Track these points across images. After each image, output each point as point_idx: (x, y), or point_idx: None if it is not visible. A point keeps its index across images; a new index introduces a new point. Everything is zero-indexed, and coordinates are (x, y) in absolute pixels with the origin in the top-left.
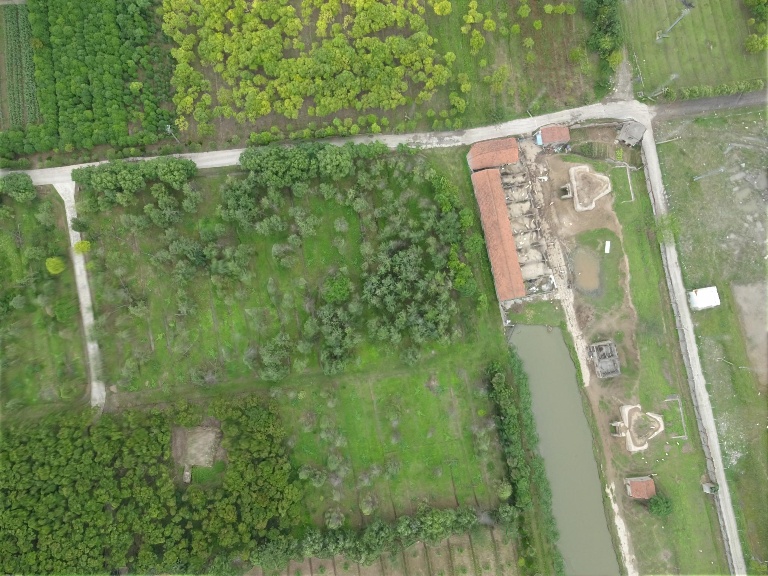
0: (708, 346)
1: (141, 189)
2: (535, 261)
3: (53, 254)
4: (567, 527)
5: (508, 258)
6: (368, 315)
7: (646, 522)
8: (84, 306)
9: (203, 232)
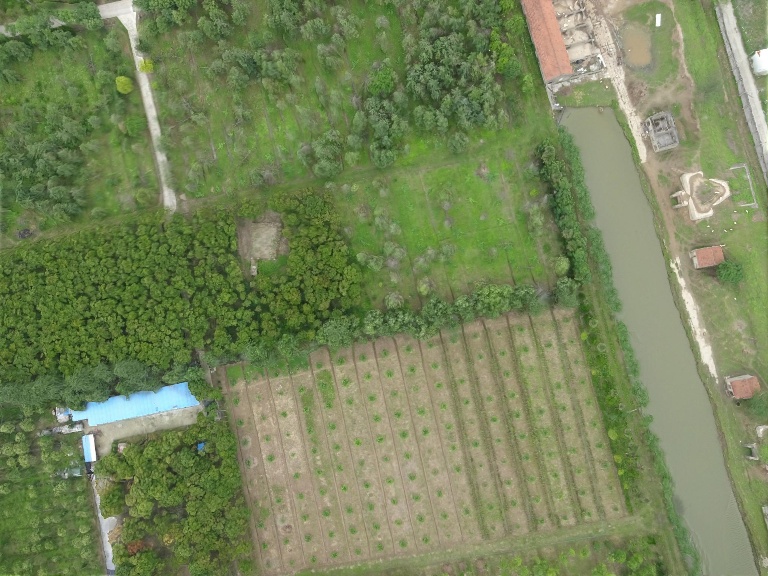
0: None
1: (193, 5)
2: (581, 41)
3: (121, 76)
4: (630, 300)
5: (552, 35)
6: (414, 107)
7: (716, 293)
8: (152, 124)
9: (252, 41)
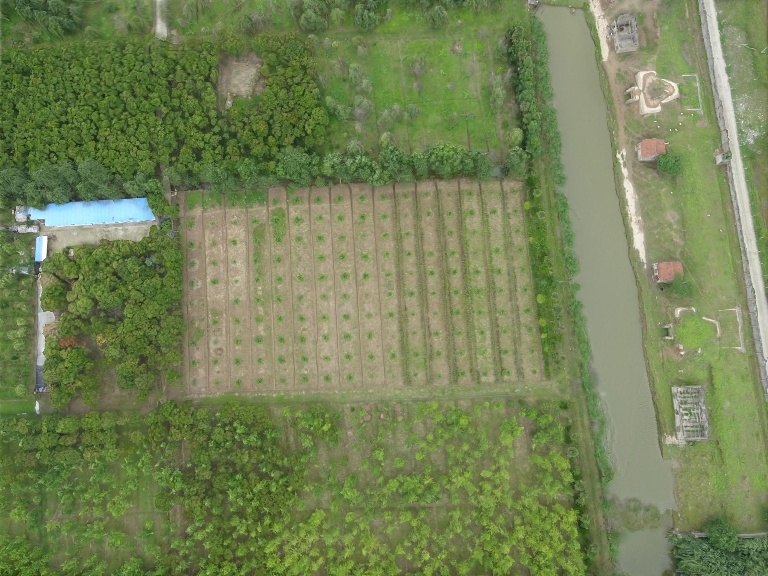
0: (731, 33)
1: None
2: None
3: None
4: (575, 179)
5: None
6: None
7: (655, 185)
8: None
9: None
